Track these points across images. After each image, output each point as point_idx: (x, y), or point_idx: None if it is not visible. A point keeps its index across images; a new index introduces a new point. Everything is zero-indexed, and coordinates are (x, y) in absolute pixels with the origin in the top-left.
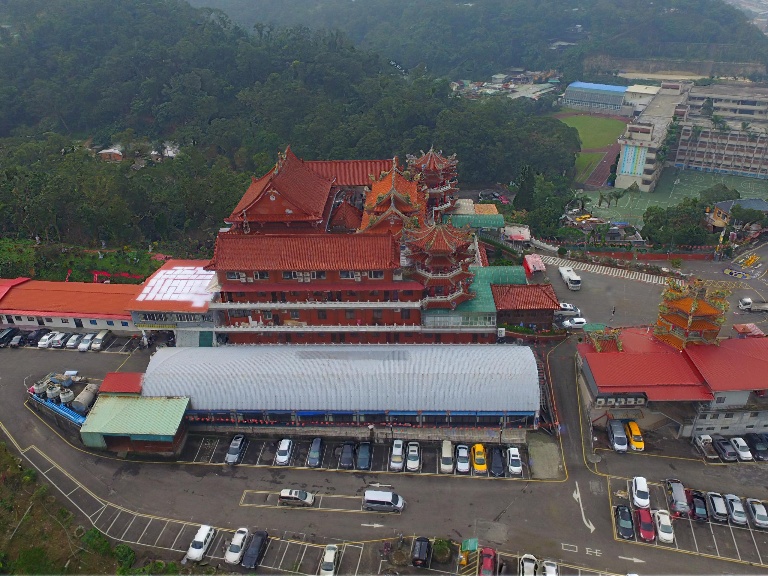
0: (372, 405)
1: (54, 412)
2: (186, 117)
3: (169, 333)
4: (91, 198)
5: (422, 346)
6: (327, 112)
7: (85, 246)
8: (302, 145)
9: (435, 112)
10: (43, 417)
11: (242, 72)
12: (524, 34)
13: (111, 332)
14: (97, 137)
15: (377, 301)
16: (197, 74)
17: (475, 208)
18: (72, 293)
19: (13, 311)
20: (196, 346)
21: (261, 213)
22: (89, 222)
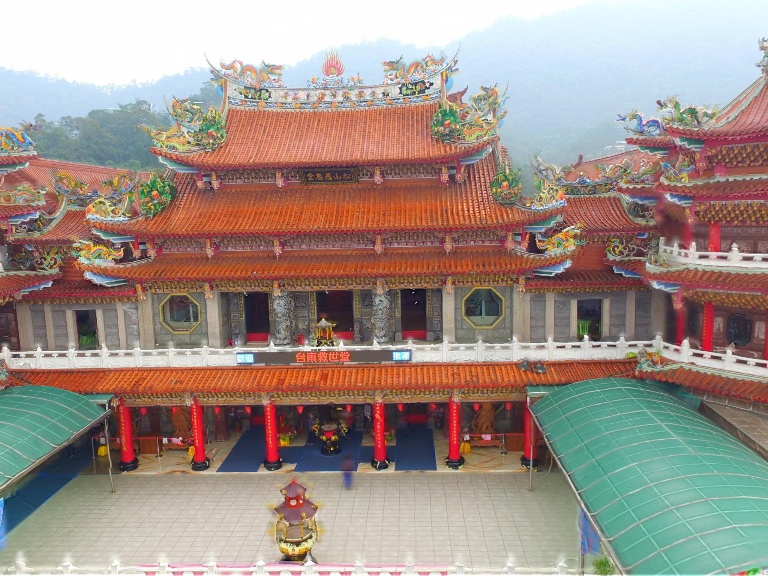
0: None
1: None
2: None
3: None
4: None
5: None
6: None
7: None
8: None
9: None
10: None
11: None
12: None
13: None
14: None
15: None
16: None
17: None
18: None
19: None
20: None
21: None
22: None
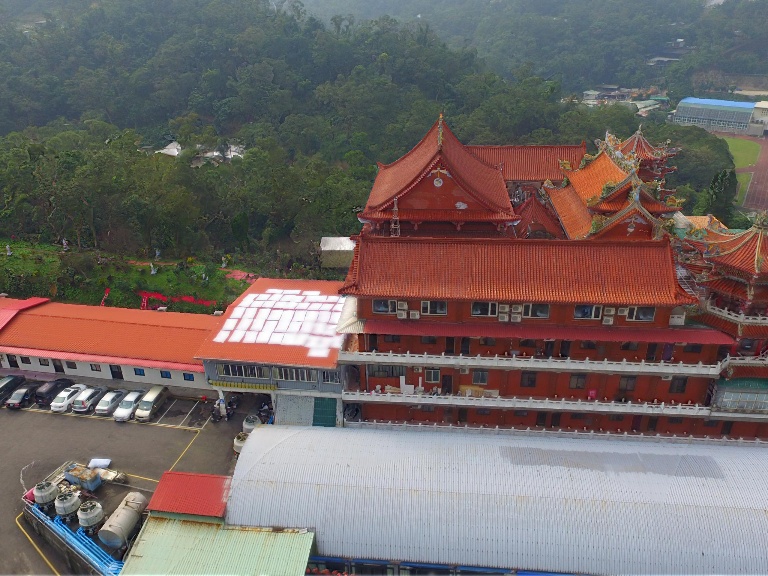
0: (671, 569)
1: (65, 545)
2: (252, 116)
3: (259, 396)
4: (144, 188)
5: (723, 446)
6: (425, 110)
7: (131, 256)
8: (397, 147)
9: (551, 116)
10: (45, 549)
11: (318, 67)
12: (619, 47)
13: (167, 390)
14: (147, 136)
15: (640, 361)
16: (269, 64)
17: (688, 221)
18: (109, 324)
19: (17, 349)
20: (308, 422)
21: (415, 207)
22: (139, 221)
